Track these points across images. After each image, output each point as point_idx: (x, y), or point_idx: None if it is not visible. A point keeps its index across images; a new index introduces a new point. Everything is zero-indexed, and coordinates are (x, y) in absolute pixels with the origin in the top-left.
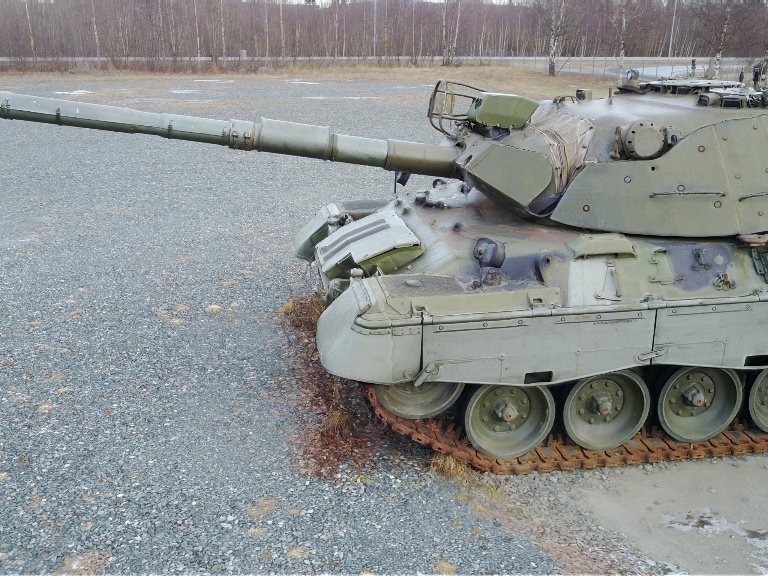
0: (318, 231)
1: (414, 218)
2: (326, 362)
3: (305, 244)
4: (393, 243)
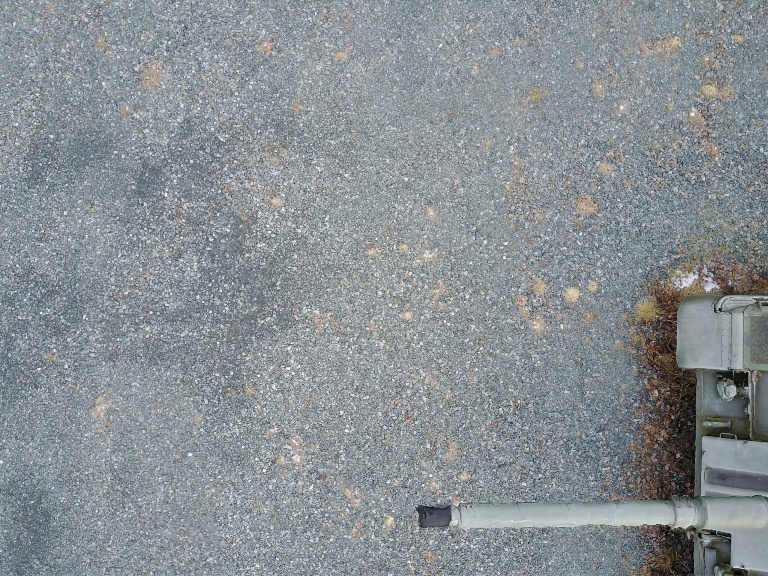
0: (711, 369)
1: None
2: None
3: (692, 368)
4: None
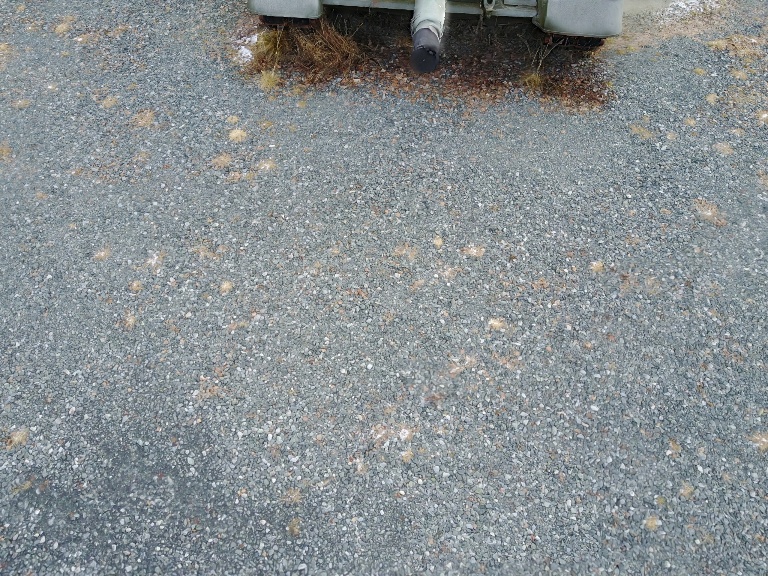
0: None
1: None
2: (612, 32)
3: None
4: None
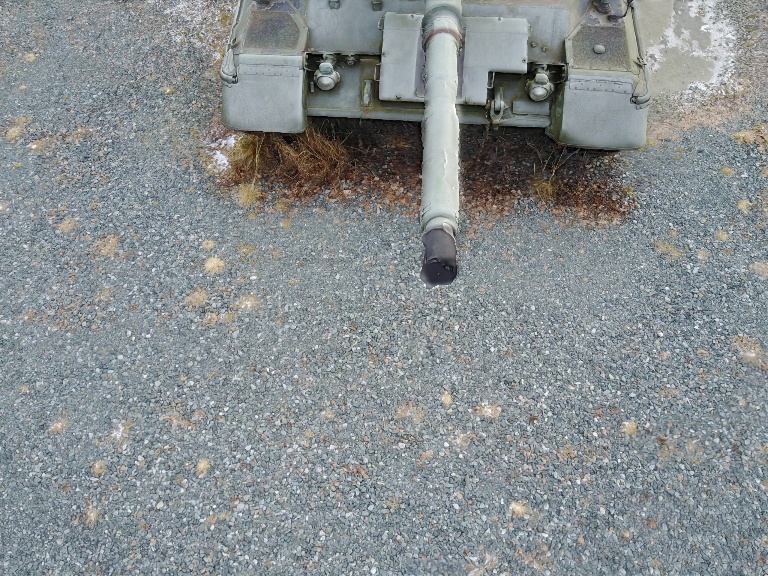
0: None
1: (412, 6)
2: (636, 145)
3: None
4: (523, 36)
